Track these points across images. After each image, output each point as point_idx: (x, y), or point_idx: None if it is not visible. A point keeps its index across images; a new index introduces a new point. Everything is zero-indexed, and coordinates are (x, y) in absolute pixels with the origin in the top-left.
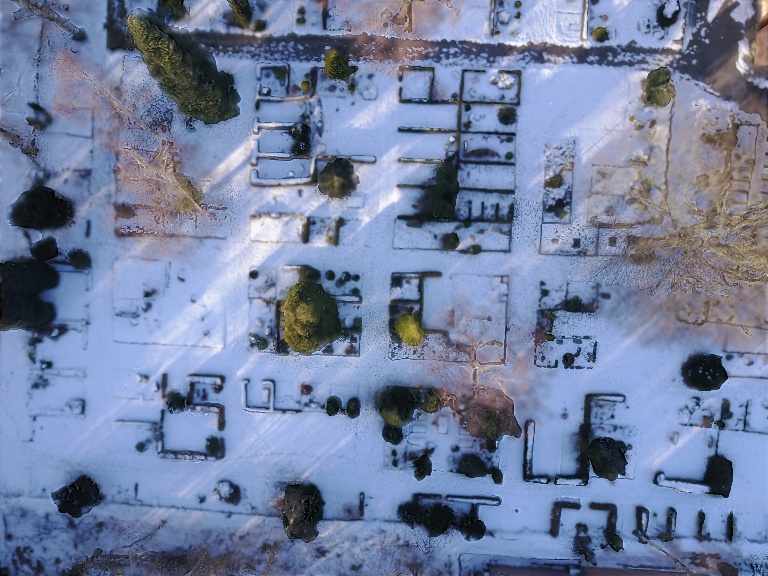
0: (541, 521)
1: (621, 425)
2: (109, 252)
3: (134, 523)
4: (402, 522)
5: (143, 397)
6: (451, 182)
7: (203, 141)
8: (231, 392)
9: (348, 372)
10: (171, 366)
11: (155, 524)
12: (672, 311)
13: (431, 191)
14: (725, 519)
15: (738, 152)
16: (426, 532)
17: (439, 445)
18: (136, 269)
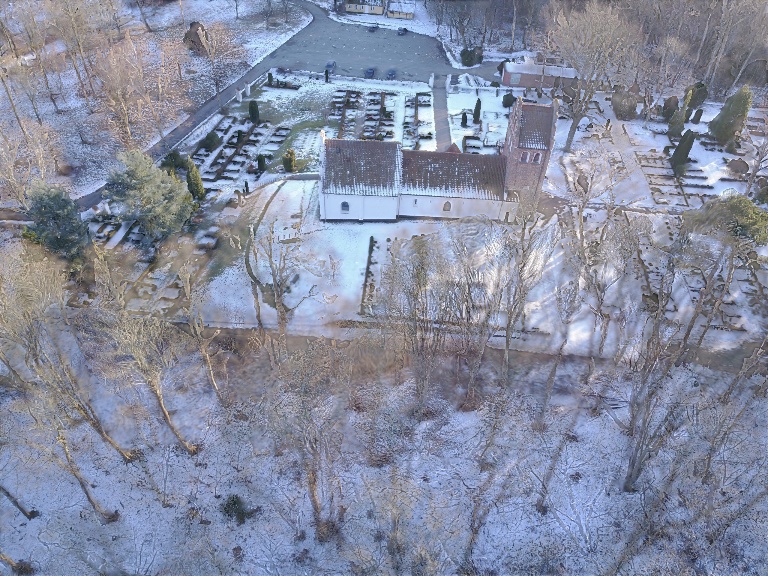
0: None
1: None
2: None
3: None
4: None
5: None
6: (693, 135)
7: None
8: None
9: (694, 129)
10: None
11: None
12: None
13: None
14: None
15: None
16: None
17: None
18: None
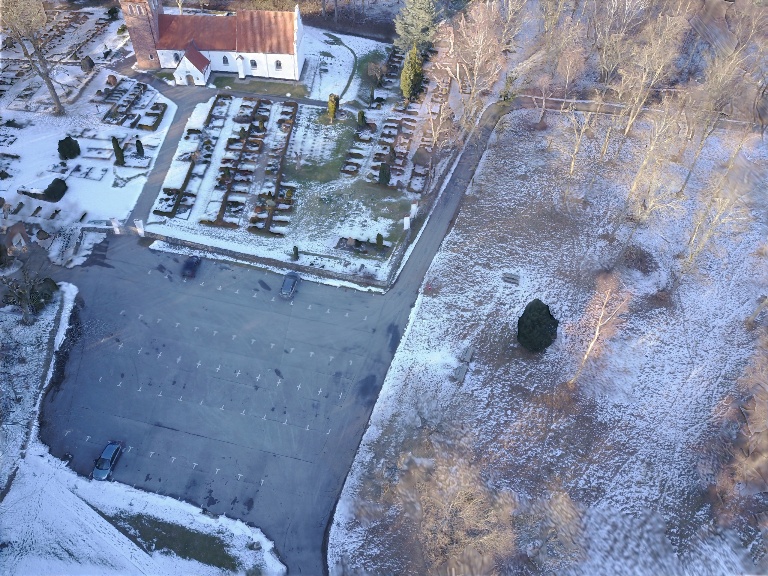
0: None
1: (12, 169)
2: None
3: None
4: None
5: None
6: None
7: None
8: None
9: None
10: None
11: None
12: None
13: None
14: None
15: (121, 87)
16: None
17: None
18: None
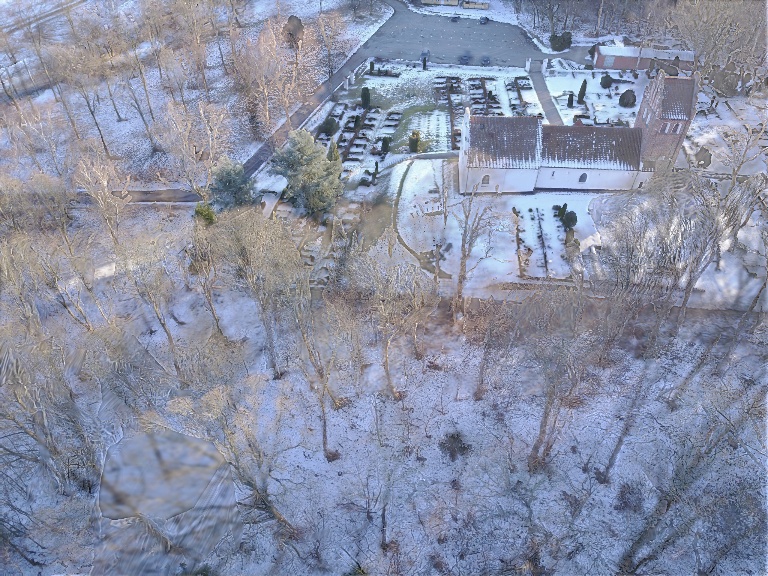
0: None
1: None
2: None
3: None
4: None
5: None
6: None
7: None
8: None
9: None
10: None
11: None
12: None
13: None
14: None
15: None
16: None
17: (738, 89)
18: None
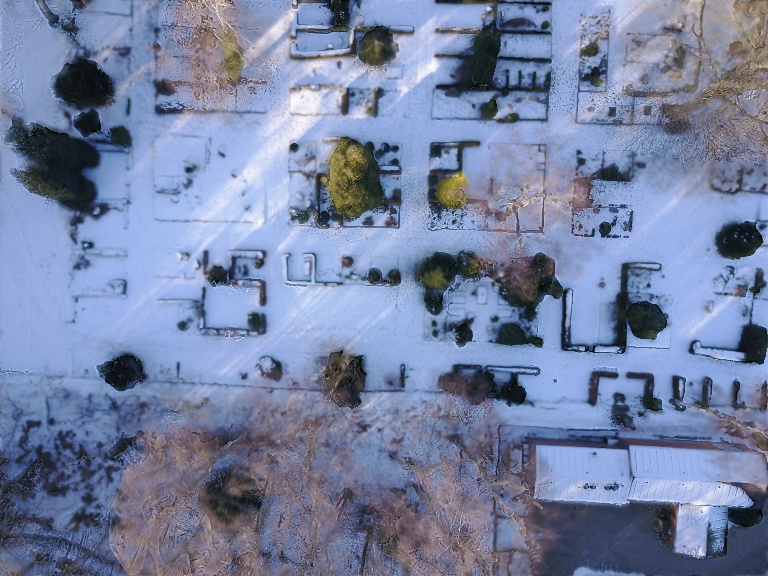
0: (579, 391)
1: (657, 294)
2: (149, 130)
3: (176, 402)
4: (442, 392)
5: (184, 275)
6: (494, 34)
7: (242, 16)
8: (272, 267)
9: (388, 244)
10: (212, 243)
11: (197, 402)
12: (706, 180)
13: (469, 61)
14: (759, 388)
15: None
16: (467, 400)
17: (478, 316)
18: (177, 146)
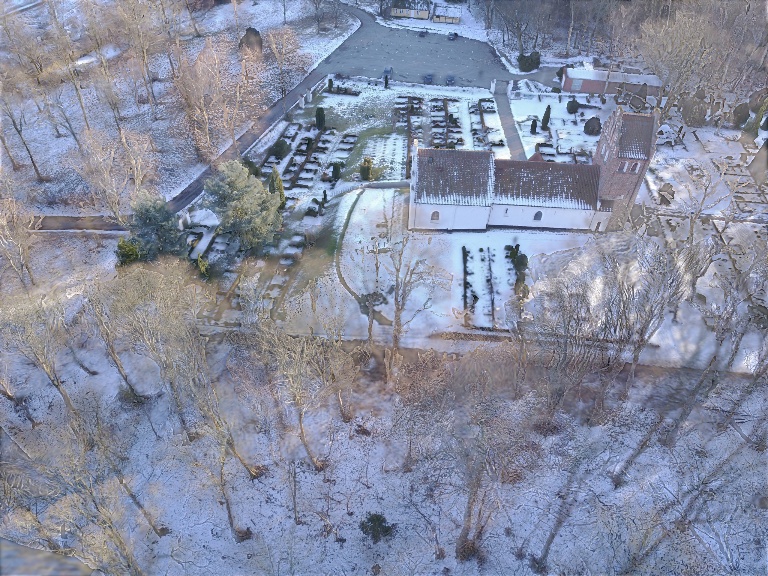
0: None
1: None
2: None
3: None
4: None
5: None
6: None
7: None
8: None
9: None
10: None
11: None
12: None
13: None
14: None
15: None
16: None
17: (707, 118)
18: None
